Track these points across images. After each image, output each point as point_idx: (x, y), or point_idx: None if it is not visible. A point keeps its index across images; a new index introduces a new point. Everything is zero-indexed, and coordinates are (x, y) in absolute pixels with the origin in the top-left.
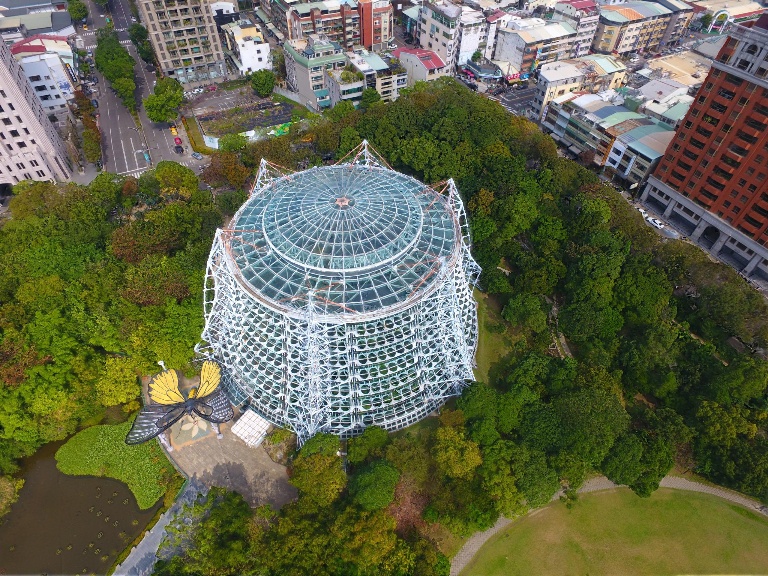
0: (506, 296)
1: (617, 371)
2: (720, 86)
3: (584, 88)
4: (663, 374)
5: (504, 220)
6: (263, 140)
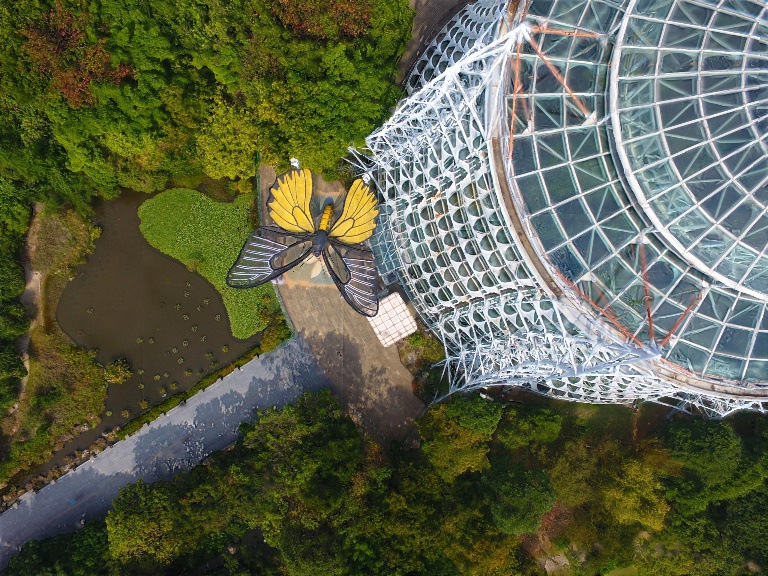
0: None
1: None
2: None
3: None
4: None
5: None
6: None
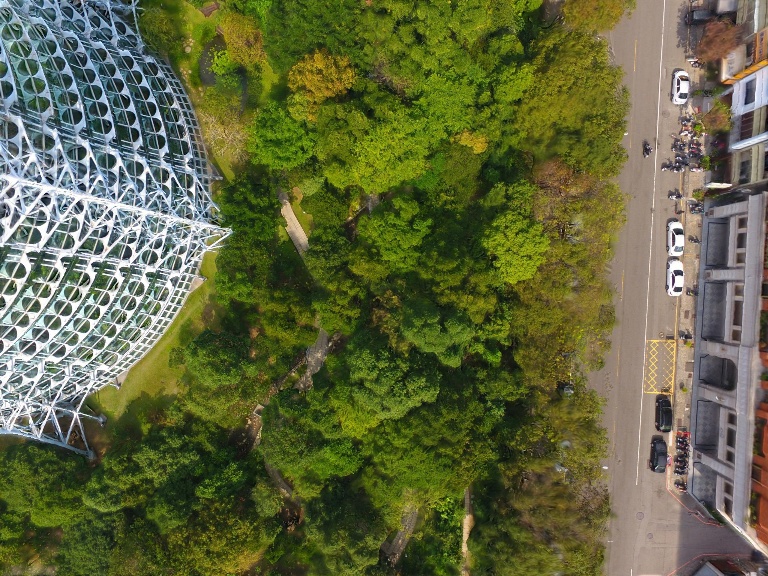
0: (226, 311)
1: (265, 536)
2: None
3: None
4: (331, 570)
5: None
6: None
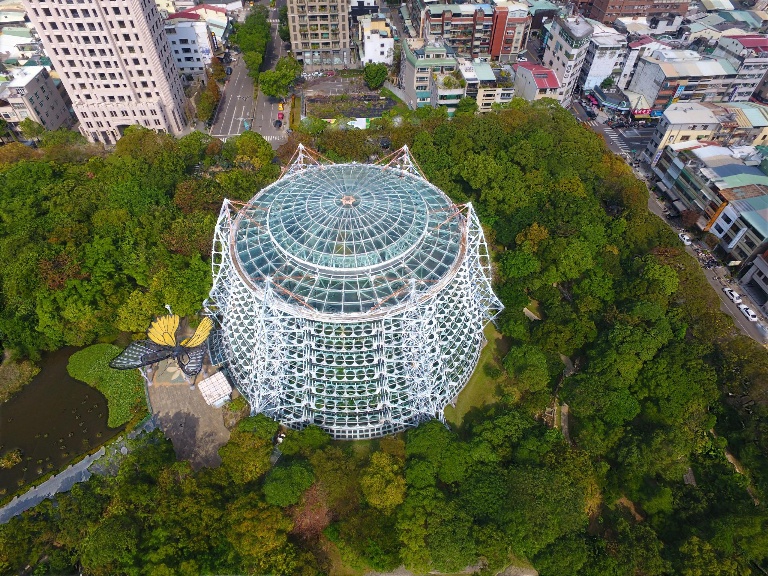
0: (516, 342)
1: (603, 463)
2: None
3: (717, 138)
4: (661, 487)
5: (550, 262)
6: (340, 129)
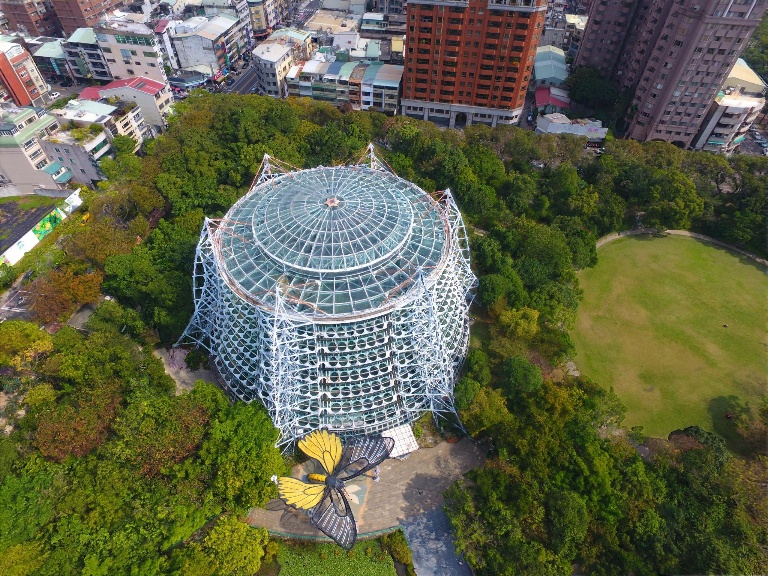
0: None
1: (523, 216)
2: (420, 15)
3: (295, 59)
4: (538, 202)
5: None
6: (82, 235)
